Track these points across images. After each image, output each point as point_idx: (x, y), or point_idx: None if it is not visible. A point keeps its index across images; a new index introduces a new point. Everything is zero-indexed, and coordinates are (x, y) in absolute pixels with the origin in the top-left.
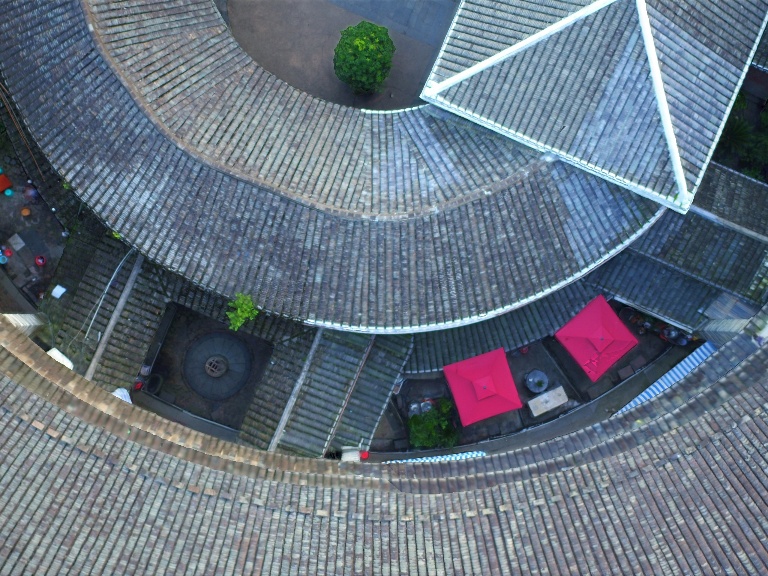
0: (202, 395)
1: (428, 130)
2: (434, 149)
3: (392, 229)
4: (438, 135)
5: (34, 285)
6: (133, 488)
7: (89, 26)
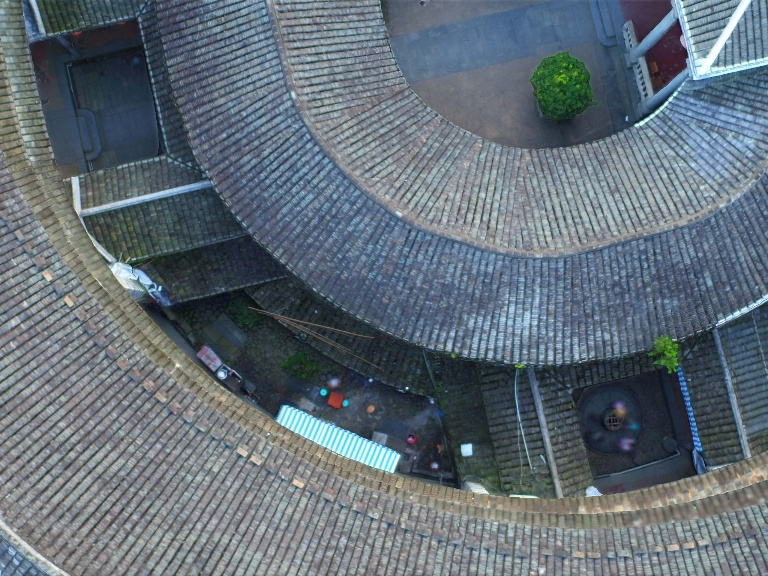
0: (615, 452)
1: (703, 103)
2: (722, 114)
3: (746, 200)
4: (715, 101)
5: (419, 462)
6: None
7: (397, 214)
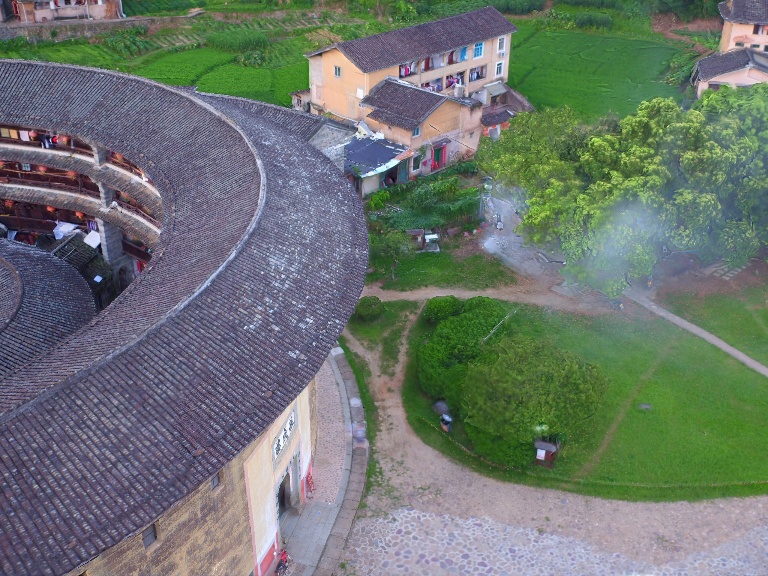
0: None
1: None
2: None
3: None
4: None
5: None
6: (2, 109)
7: None
